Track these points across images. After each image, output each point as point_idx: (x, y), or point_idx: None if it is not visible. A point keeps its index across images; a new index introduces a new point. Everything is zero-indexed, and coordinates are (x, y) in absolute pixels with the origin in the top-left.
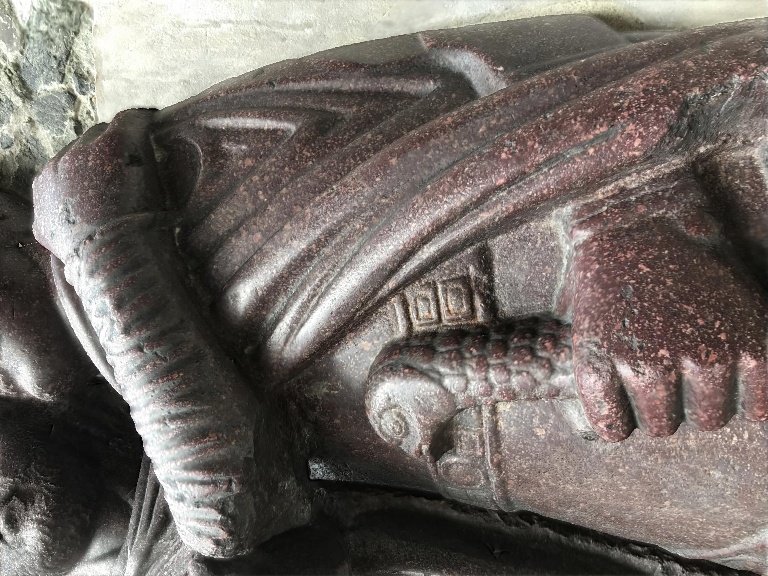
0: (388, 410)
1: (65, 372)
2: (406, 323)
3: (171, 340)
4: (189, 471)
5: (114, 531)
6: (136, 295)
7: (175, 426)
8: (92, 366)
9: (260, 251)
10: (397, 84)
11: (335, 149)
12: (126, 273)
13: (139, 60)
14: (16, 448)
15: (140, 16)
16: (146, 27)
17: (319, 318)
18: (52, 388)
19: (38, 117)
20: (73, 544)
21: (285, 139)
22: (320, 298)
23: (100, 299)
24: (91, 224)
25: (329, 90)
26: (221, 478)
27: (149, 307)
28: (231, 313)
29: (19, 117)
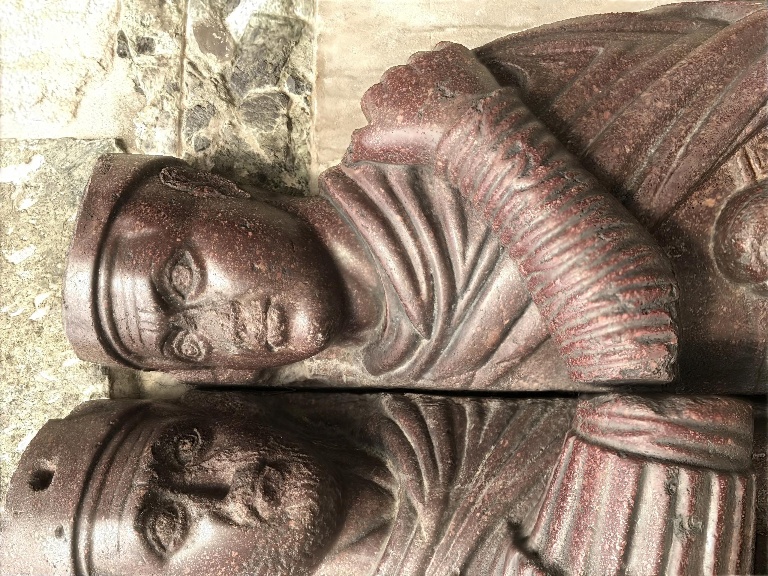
0: (767, 234)
1: (336, 313)
2: (751, 172)
3: (583, 172)
4: (633, 279)
5: (369, 510)
6: (543, 137)
7: (611, 238)
8: (347, 318)
9: (621, 118)
10: (666, 25)
11: (645, 58)
12: (528, 122)
13: (363, 60)
14: (244, 428)
15: (366, 26)
16: (372, 34)
17: (691, 162)
18: (326, 327)
19: (246, 116)
20: (331, 524)
21: (596, 56)
22: (689, 145)
23: (511, 141)
24: (476, 93)
25: (614, 29)
26: (663, 283)
27: (556, 147)
28: (598, 173)
29: (218, 121)
